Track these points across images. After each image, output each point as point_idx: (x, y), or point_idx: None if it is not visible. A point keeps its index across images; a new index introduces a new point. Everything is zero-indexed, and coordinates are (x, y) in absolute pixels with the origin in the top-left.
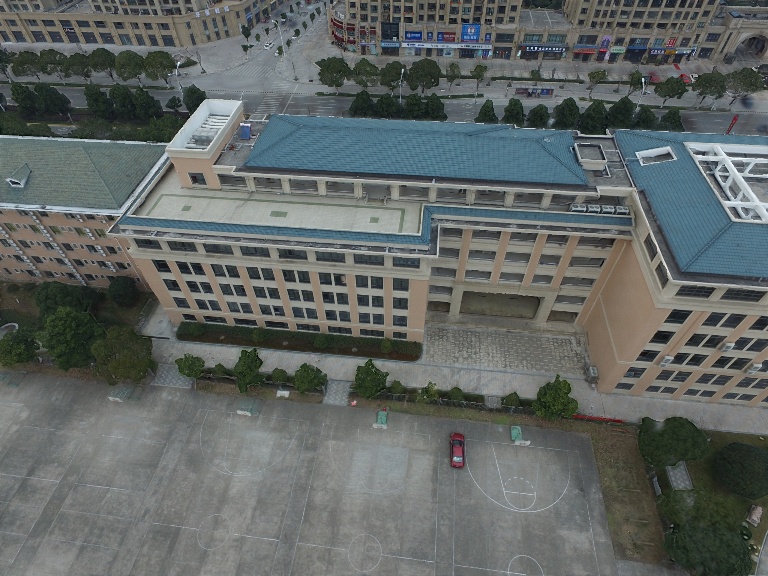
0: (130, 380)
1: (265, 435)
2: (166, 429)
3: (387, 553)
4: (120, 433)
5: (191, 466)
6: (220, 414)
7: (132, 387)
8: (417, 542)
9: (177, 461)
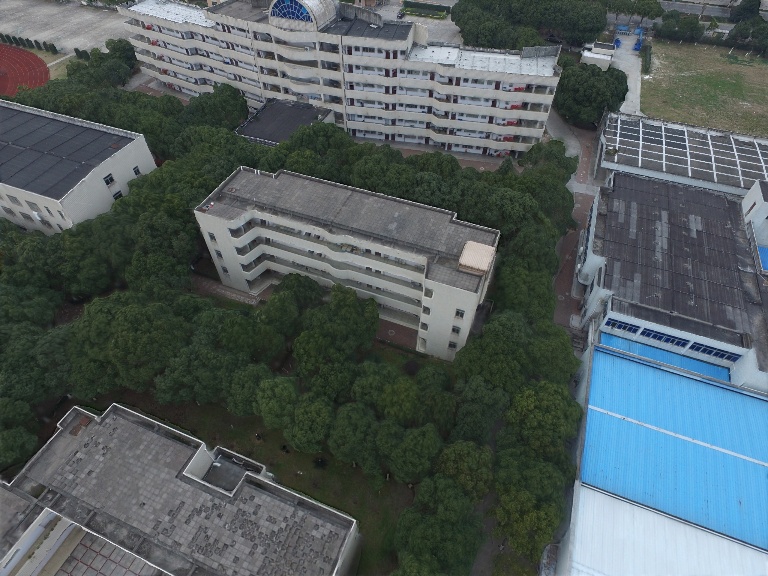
0: (59, 3)
1: (91, 15)
2: (62, 11)
3: (104, 33)
4: (47, 10)
5: (63, 17)
6: (81, 11)
7: (58, 4)
8: (114, 33)
9: (60, 16)
